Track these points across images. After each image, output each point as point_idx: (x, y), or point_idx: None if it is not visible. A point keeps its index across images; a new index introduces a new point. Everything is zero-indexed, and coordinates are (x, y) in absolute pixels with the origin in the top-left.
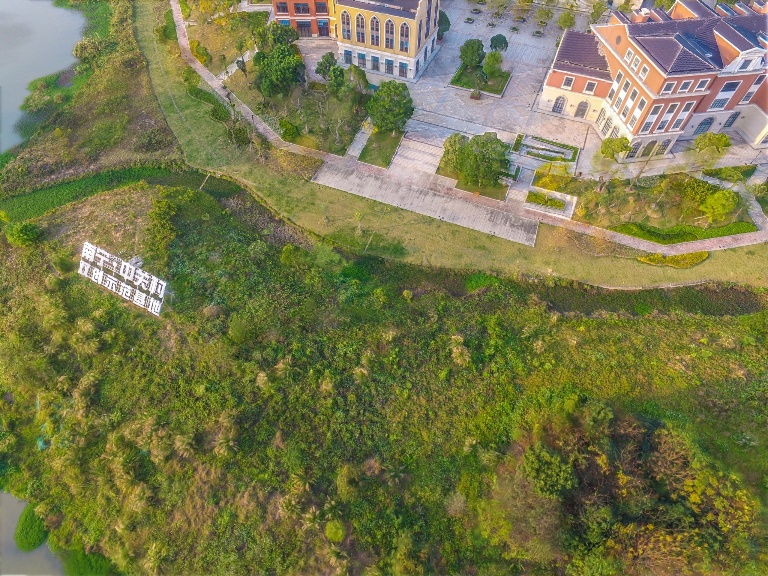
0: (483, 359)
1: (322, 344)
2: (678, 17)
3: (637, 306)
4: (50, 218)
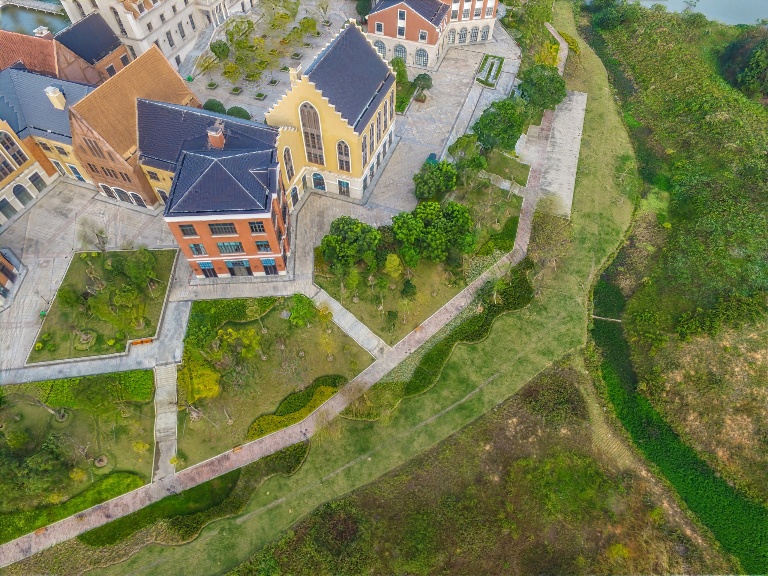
0: (711, 111)
1: (763, 177)
2: None
3: (613, 63)
4: (767, 477)
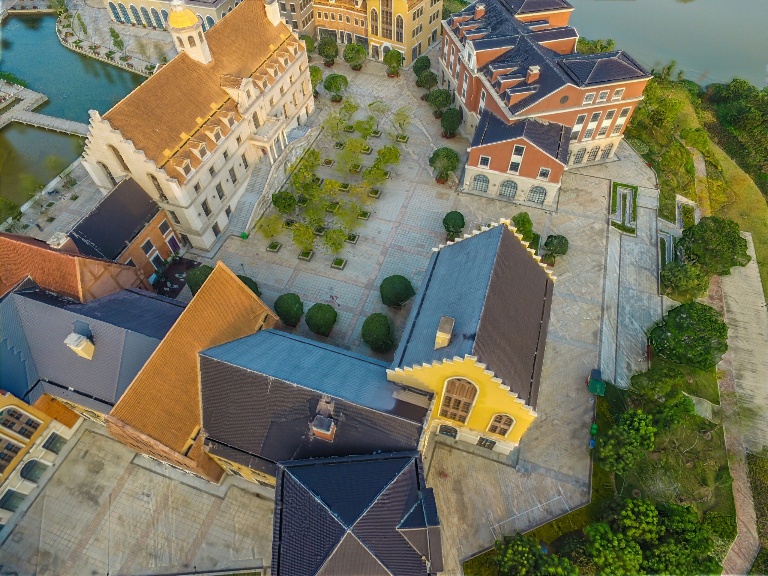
0: None
1: None
2: (485, 61)
3: (765, 180)
4: None
